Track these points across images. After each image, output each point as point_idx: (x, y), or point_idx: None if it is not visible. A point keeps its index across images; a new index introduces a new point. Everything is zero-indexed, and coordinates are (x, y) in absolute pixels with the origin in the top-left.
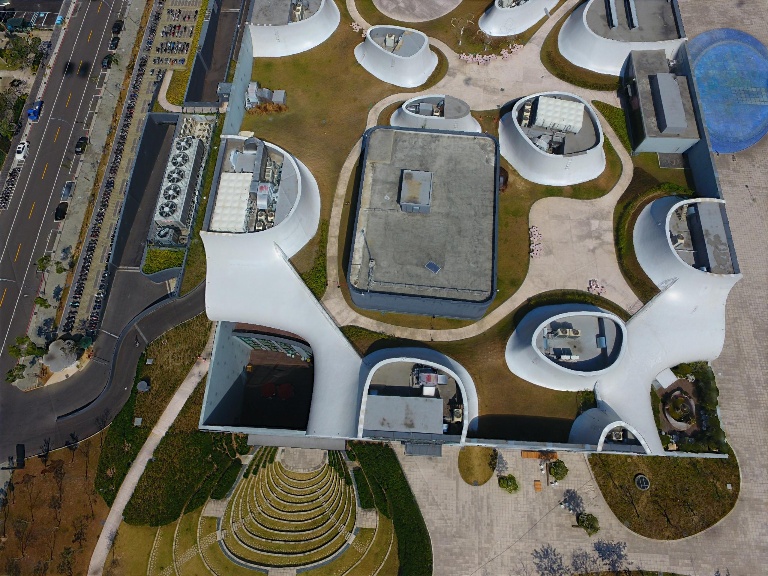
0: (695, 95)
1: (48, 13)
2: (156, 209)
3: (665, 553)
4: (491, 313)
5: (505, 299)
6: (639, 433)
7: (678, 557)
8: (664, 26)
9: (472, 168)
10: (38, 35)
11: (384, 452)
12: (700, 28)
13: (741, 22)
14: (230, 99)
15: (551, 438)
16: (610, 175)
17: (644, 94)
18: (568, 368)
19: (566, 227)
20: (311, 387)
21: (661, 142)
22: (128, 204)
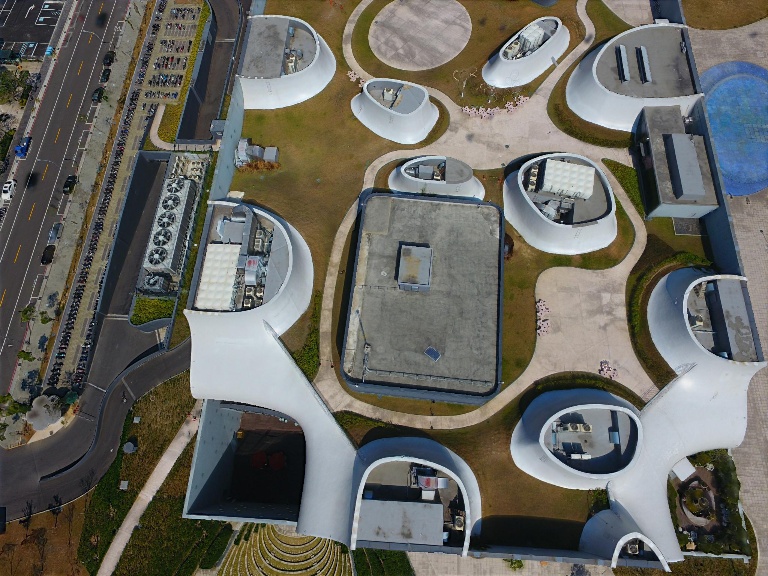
0: (713, 157)
1: (38, 43)
2: (145, 255)
3: None
4: (495, 397)
5: (510, 382)
6: (657, 547)
7: None
8: (679, 80)
9: (475, 241)
10: (27, 67)
11: None
12: (711, 61)
13: (754, 54)
14: (218, 160)
15: (560, 543)
16: (622, 243)
17: (658, 155)
18: (579, 468)
19: (575, 301)
20: None
21: (677, 208)
22: (117, 248)
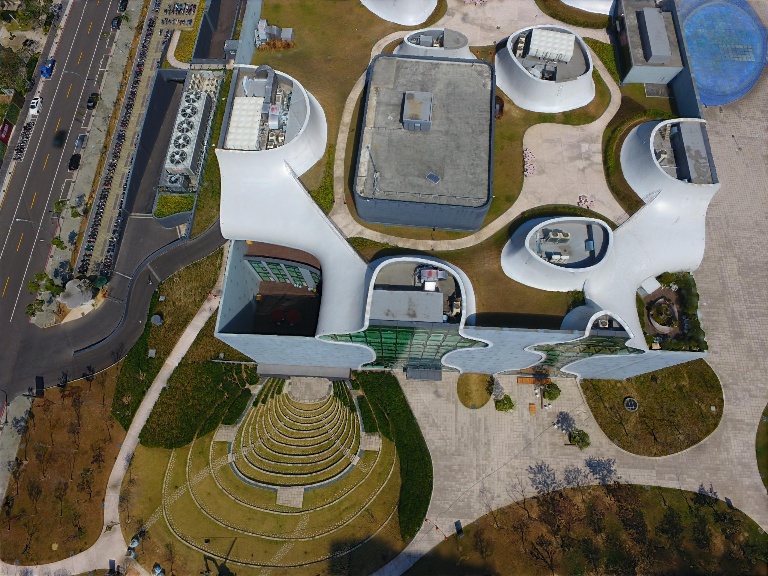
0: (679, 28)
1: None
2: (167, 157)
3: (652, 468)
4: (488, 226)
5: (501, 213)
6: (623, 320)
7: (664, 472)
8: None
9: (470, 91)
10: None
11: (387, 379)
12: None
13: None
14: (241, 32)
15: None
16: (599, 103)
17: (631, 28)
18: (559, 267)
19: (558, 149)
20: (317, 314)
21: (647, 71)
22: (139, 154)
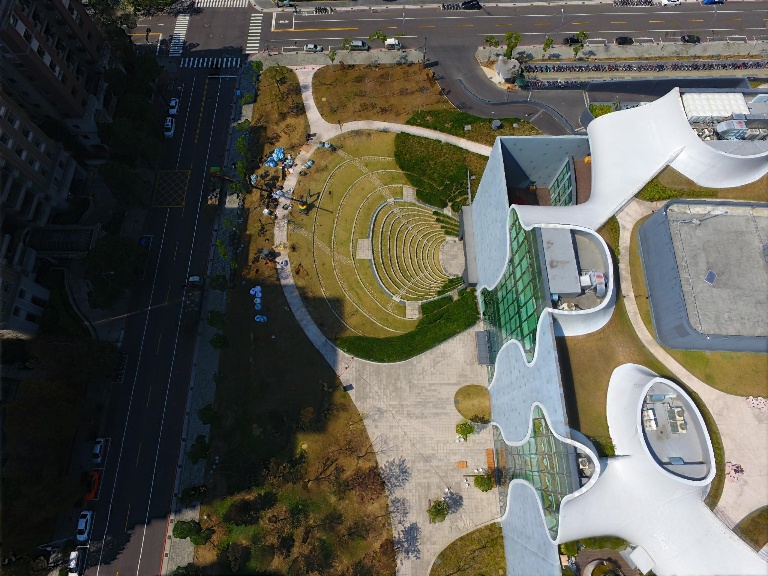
0: None
1: None
2: None
3: None
4: (668, 354)
5: (688, 368)
6: None
7: None
8: None
9: None
10: None
11: (473, 316)
12: None
13: None
14: None
15: None
16: None
17: None
18: None
19: None
20: None
21: None
22: (647, 83)
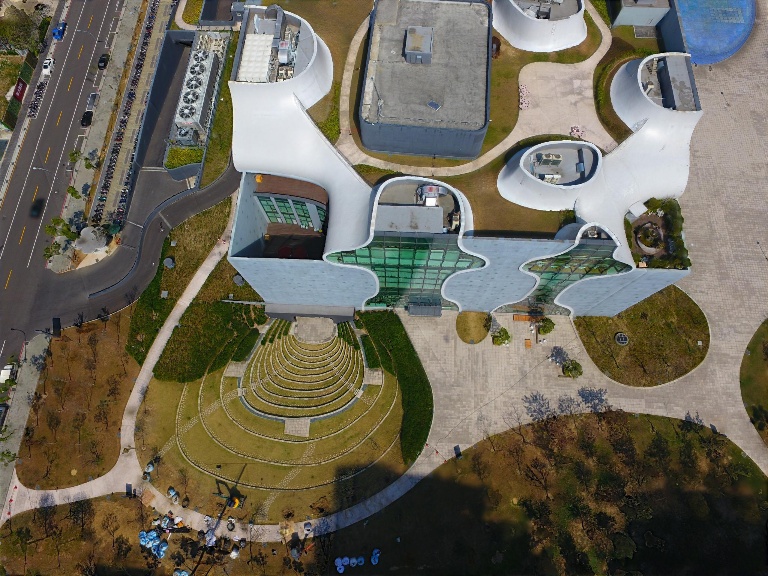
0: None
1: None
2: (176, 112)
3: (641, 398)
4: (485, 154)
5: (497, 143)
6: None
7: (653, 401)
8: None
9: (468, 28)
10: None
11: (389, 316)
12: None
13: None
14: None
15: None
16: (591, 43)
17: None
18: None
19: (551, 85)
20: None
21: (636, 13)
22: (149, 111)
